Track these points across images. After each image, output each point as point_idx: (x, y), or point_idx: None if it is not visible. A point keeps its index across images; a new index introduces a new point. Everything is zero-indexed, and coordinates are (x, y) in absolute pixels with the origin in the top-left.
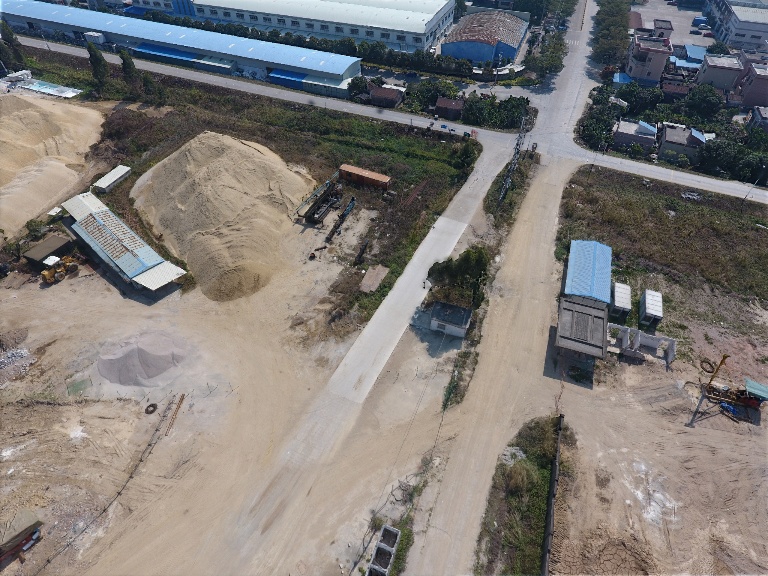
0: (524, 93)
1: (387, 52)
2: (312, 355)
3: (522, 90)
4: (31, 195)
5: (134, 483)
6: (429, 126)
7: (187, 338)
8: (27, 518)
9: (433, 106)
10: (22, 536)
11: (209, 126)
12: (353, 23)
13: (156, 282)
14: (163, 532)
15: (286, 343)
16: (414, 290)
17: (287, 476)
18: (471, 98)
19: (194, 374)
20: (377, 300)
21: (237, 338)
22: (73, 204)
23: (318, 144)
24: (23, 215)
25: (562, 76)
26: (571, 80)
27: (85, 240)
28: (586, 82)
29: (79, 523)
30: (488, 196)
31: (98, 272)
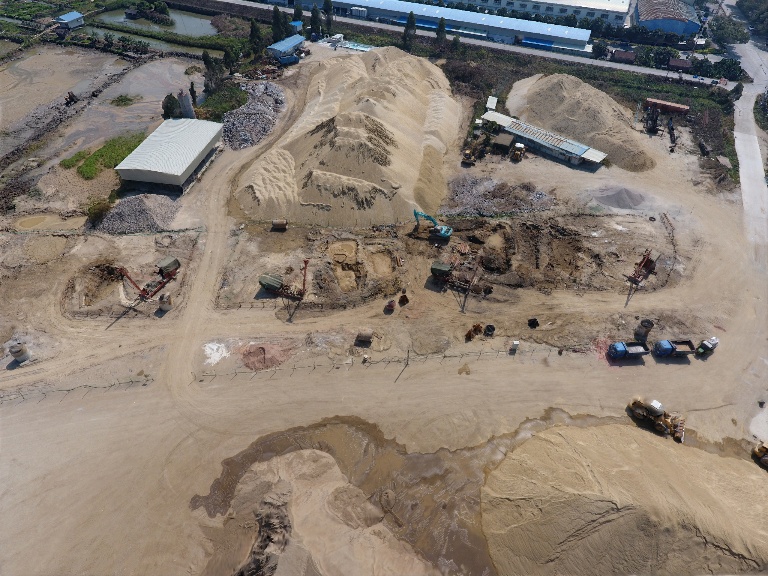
0: (721, 59)
1: (606, 26)
2: (721, 198)
3: (717, 57)
4: (449, 112)
5: (679, 248)
6: (682, 77)
7: (636, 189)
8: (655, 252)
9: (664, 65)
10: (656, 260)
11: (518, 74)
12: (564, 4)
13: (596, 158)
14: (717, 266)
15: (699, 192)
16: (754, 169)
17: (761, 247)
18: (693, 60)
19: (660, 205)
20: (735, 173)
21: (667, 189)
22: (491, 117)
23: (609, 87)
24: (453, 124)
25: (738, 48)
26: (748, 51)
27: (524, 136)
28: (760, 52)
29: (667, 262)
30: (758, 120)
31: (540, 156)
